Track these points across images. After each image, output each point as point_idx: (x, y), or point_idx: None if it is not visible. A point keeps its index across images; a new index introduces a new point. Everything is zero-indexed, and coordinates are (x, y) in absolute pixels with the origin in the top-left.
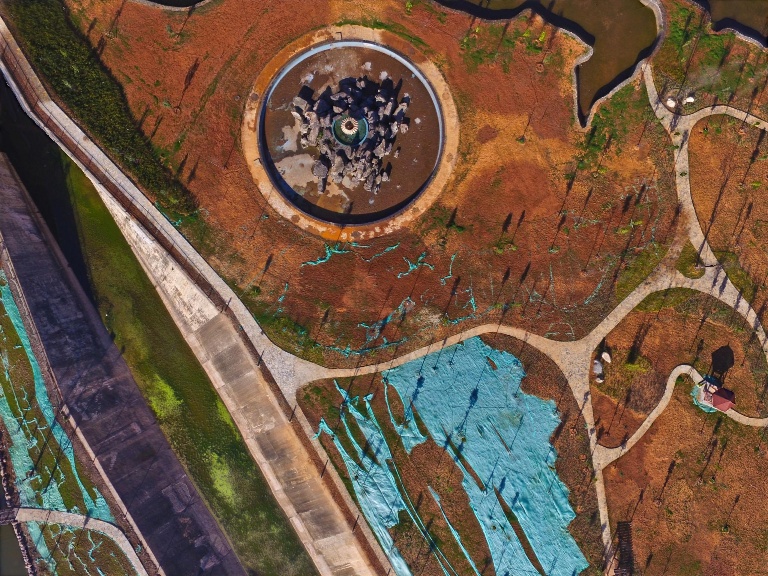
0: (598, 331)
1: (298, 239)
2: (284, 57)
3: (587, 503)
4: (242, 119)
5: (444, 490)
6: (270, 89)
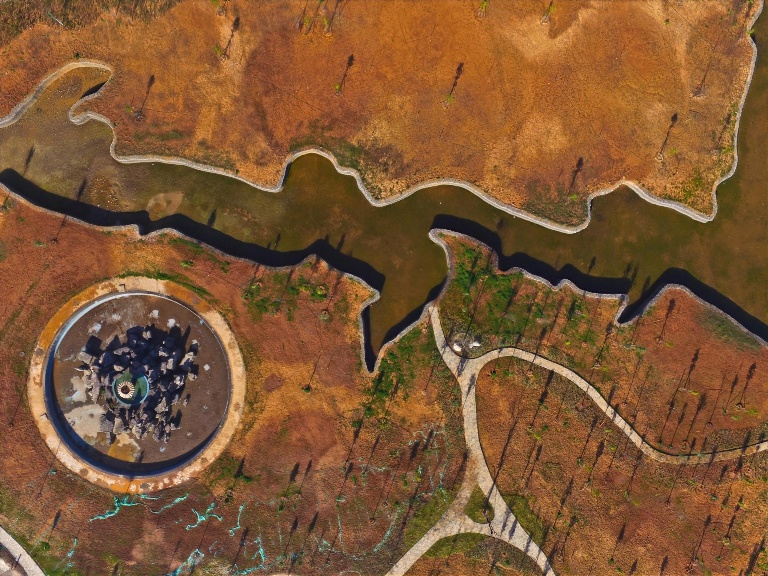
0: None
1: (87, 493)
2: (68, 311)
3: None
4: (28, 375)
5: None
6: (56, 342)
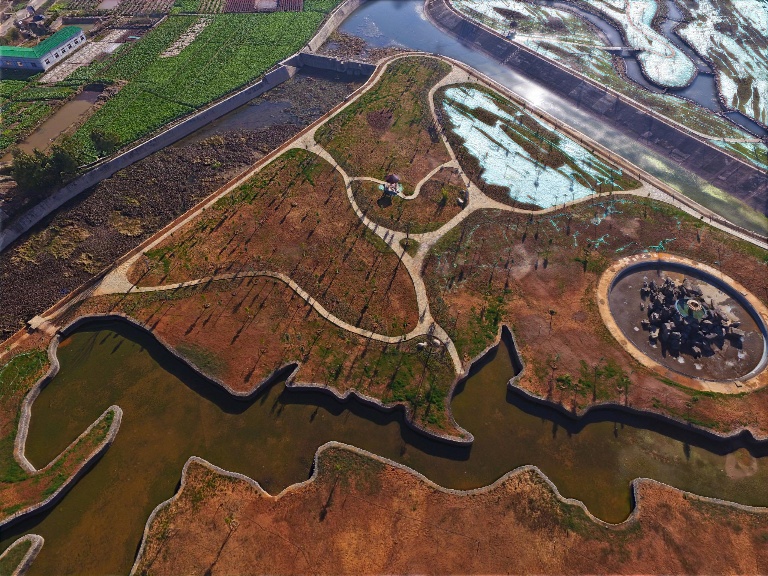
0: (468, 213)
1: (686, 252)
2: None
3: (458, 149)
4: None
5: (539, 152)
6: (767, 343)
